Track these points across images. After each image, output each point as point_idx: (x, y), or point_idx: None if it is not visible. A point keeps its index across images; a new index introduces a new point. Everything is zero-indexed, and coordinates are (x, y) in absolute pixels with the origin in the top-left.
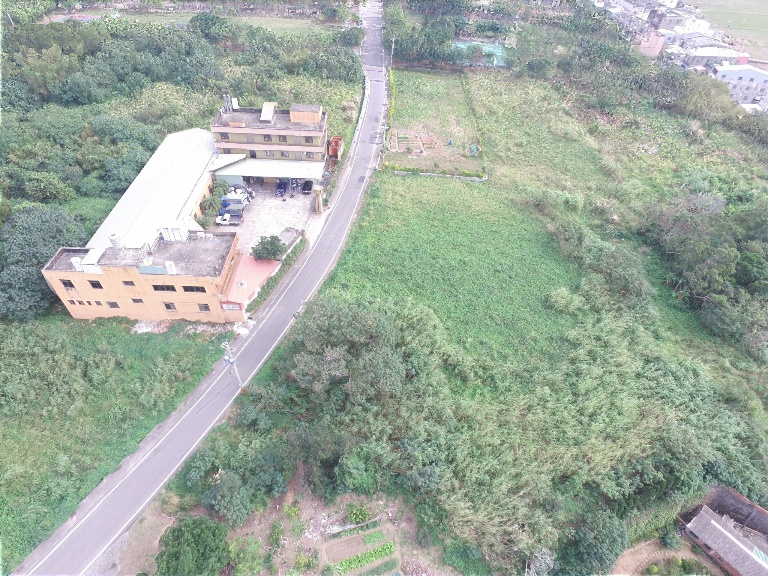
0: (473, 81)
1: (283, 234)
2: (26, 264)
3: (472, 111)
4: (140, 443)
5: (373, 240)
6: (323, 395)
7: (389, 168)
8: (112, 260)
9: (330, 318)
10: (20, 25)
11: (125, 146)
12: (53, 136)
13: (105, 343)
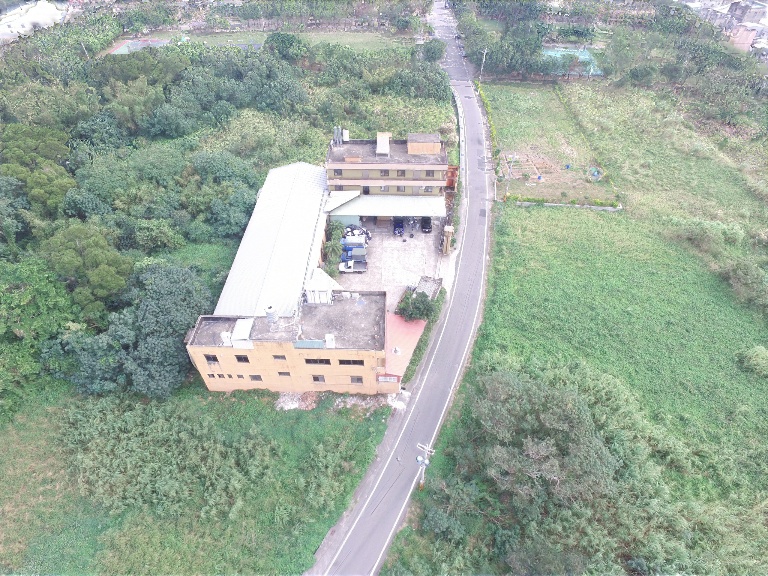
0: (570, 93)
1: (422, 285)
2: (162, 334)
3: (579, 127)
4: (316, 554)
5: (516, 287)
6: (526, 497)
7: (511, 199)
8: (264, 333)
9: (519, 399)
10: (92, 53)
11: (229, 185)
12: (155, 177)
13: (253, 424)
